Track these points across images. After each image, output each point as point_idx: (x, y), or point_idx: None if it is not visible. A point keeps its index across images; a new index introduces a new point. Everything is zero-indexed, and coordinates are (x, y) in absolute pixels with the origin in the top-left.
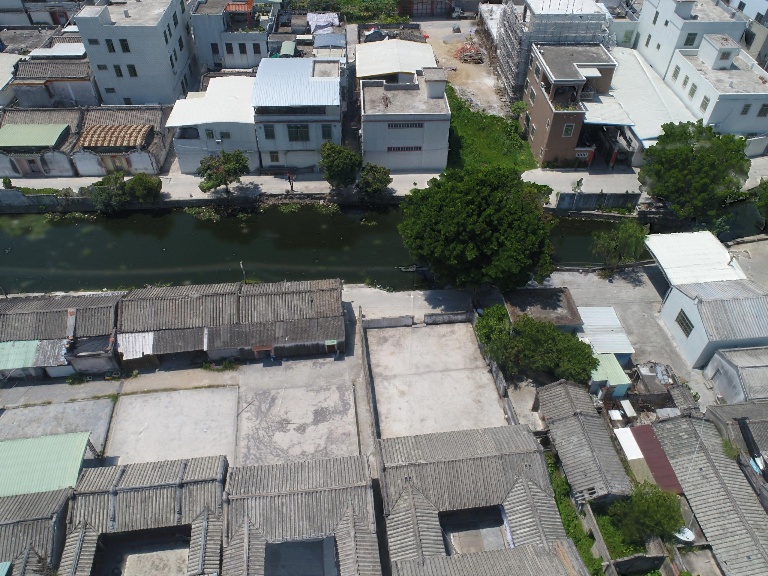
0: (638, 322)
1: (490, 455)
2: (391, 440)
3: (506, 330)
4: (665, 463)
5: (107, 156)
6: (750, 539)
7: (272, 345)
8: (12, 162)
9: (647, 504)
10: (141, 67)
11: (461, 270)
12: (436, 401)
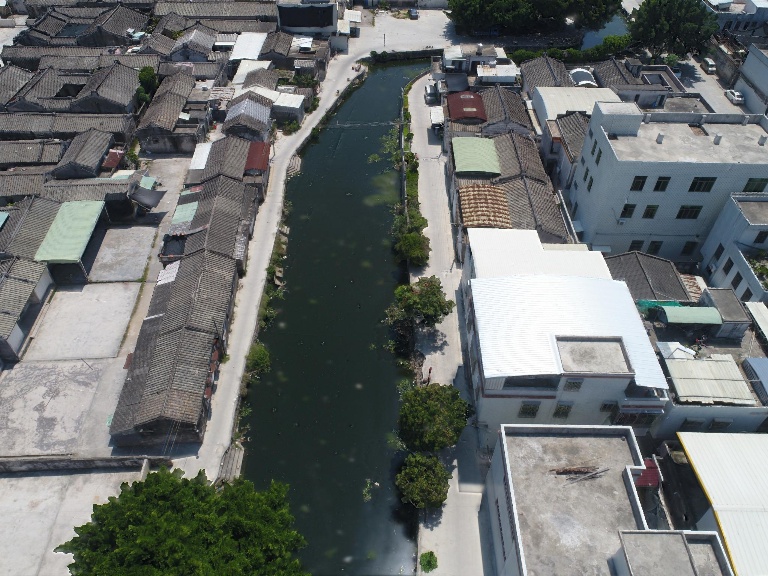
0: None
1: None
2: None
3: None
4: None
5: None
6: None
7: None
8: None
9: None
10: None
11: None
12: (4, 543)
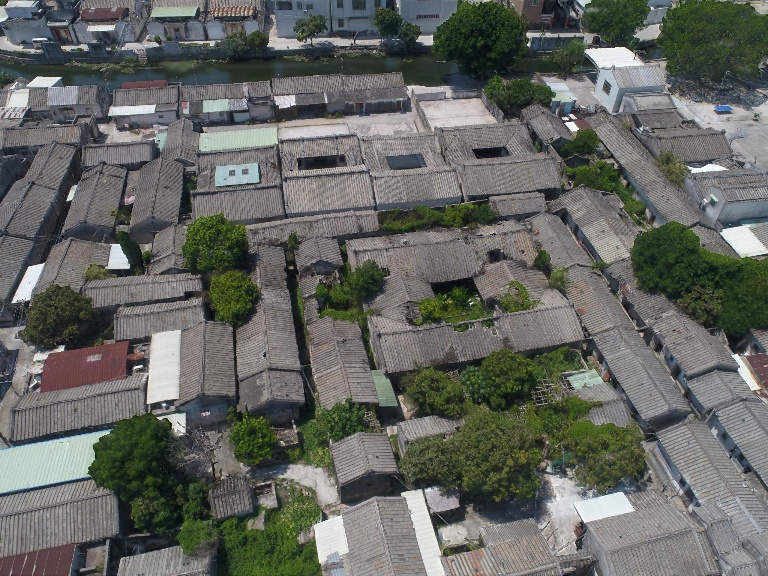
0: (581, 96)
1: (498, 126)
2: (443, 127)
3: (502, 86)
4: None
5: (229, 24)
6: (632, 147)
7: (365, 101)
8: (165, 29)
9: (580, 135)
10: None
11: (474, 60)
12: None
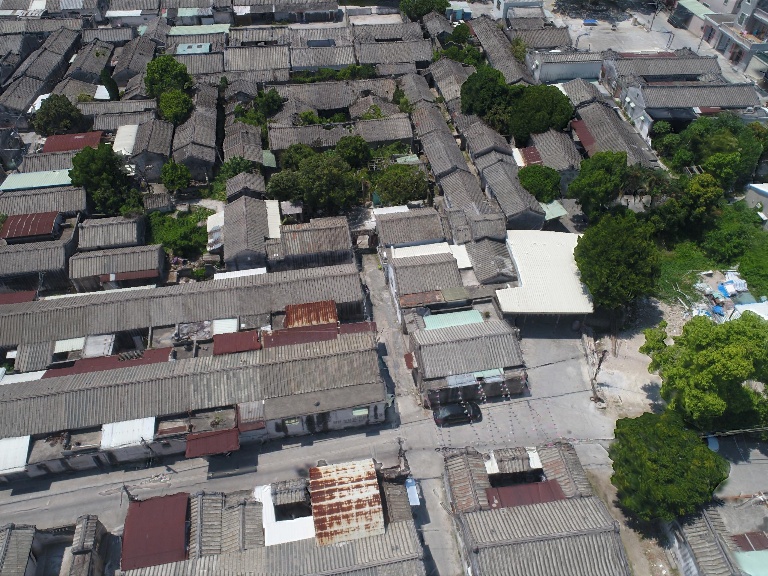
0: None
1: (397, 23)
2: None
3: None
4: (471, 29)
5: None
6: None
7: (304, 11)
8: None
9: None
10: None
11: None
12: None
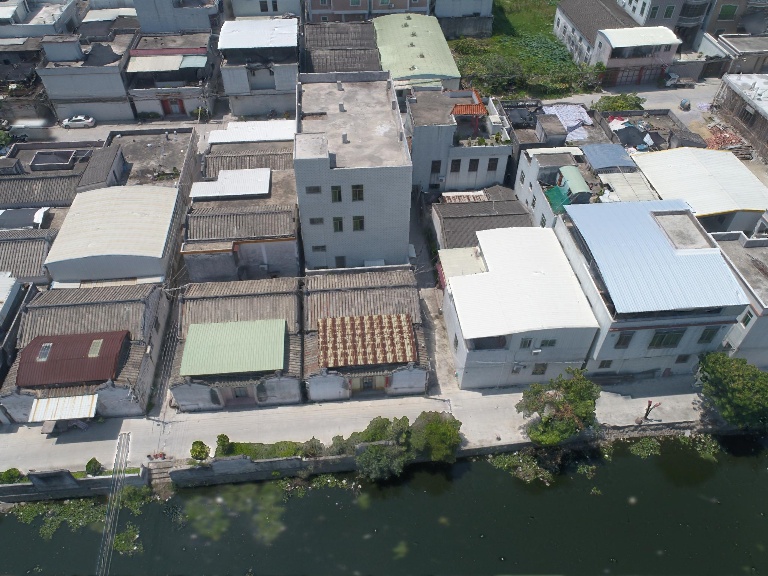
0: None
1: None
2: None
3: None
4: None
5: (360, 377)
6: None
7: None
8: (213, 392)
9: None
10: (373, 218)
11: None
12: None
